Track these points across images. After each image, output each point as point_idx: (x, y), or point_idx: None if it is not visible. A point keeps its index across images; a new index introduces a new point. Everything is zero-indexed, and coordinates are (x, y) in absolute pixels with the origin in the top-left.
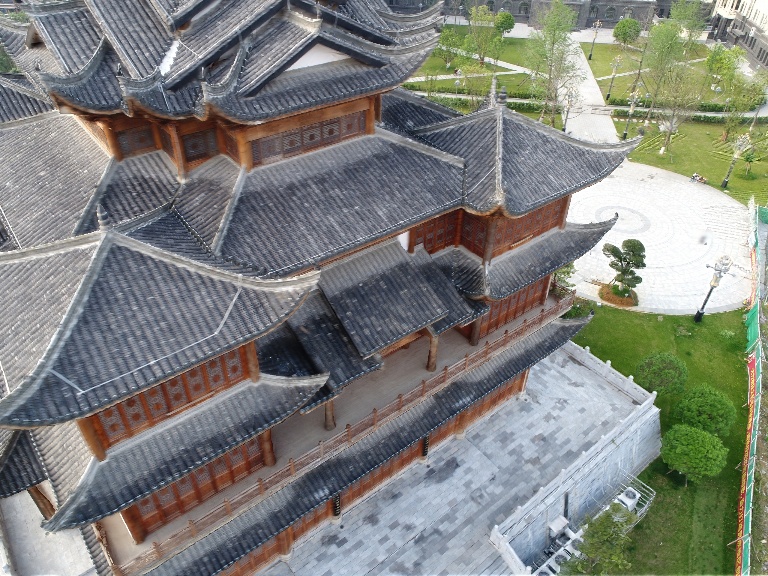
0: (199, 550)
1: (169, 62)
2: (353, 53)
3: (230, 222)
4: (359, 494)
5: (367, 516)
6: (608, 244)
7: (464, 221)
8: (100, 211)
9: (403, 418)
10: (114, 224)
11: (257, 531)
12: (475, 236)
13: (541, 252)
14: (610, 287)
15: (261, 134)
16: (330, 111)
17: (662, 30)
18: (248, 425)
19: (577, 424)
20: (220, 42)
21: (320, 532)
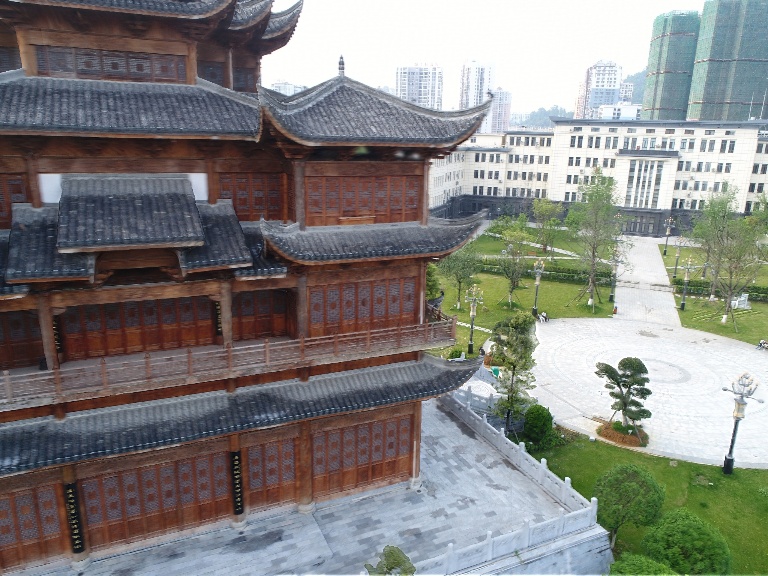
0: None
1: None
2: None
3: None
4: (123, 536)
5: (121, 569)
6: None
7: (288, 187)
8: None
9: (173, 413)
10: None
11: None
12: (294, 199)
13: (384, 237)
14: None
15: (47, 41)
16: (137, 43)
17: (713, 198)
18: None
19: (475, 527)
20: None
21: (50, 574)
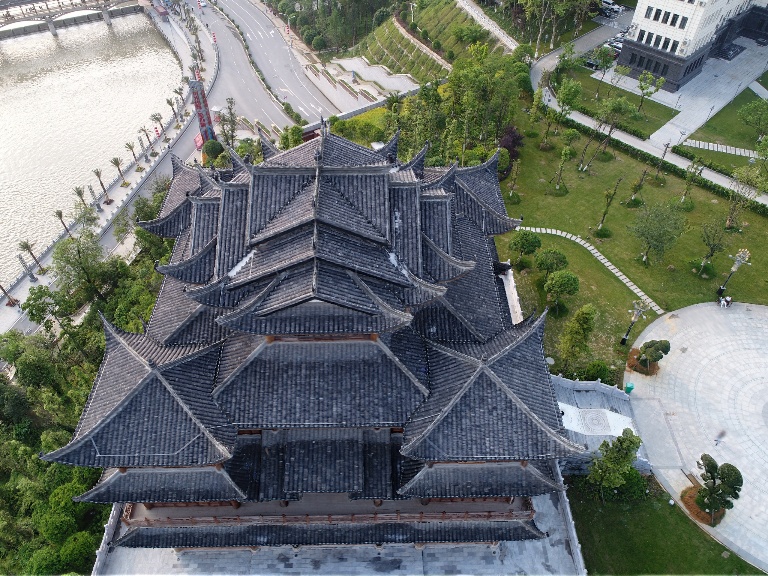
0: (180, 528)
1: (240, 267)
2: (346, 306)
3: (236, 377)
4: None
5: (315, 560)
6: (707, 456)
7: None
8: (149, 362)
9: None
10: (188, 342)
11: (215, 538)
12: None
13: (488, 476)
14: (695, 493)
15: None
16: None
17: None
18: (201, 494)
19: None
20: (263, 272)
21: (282, 549)
